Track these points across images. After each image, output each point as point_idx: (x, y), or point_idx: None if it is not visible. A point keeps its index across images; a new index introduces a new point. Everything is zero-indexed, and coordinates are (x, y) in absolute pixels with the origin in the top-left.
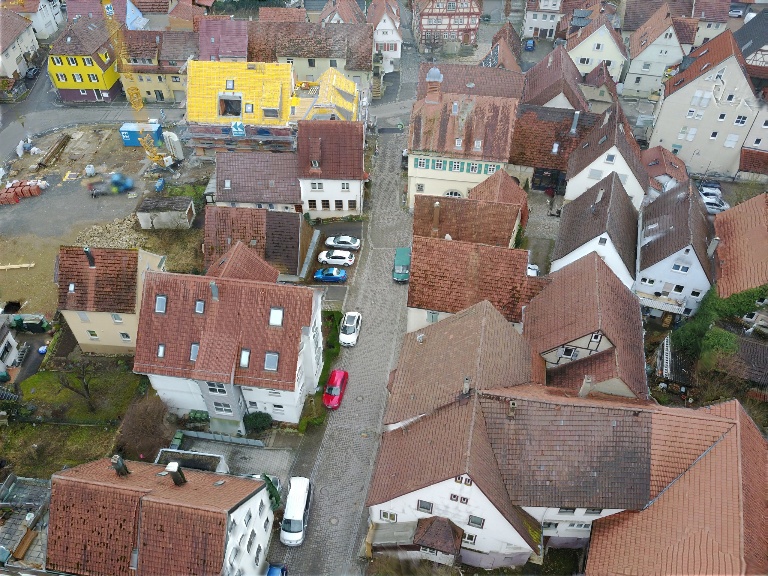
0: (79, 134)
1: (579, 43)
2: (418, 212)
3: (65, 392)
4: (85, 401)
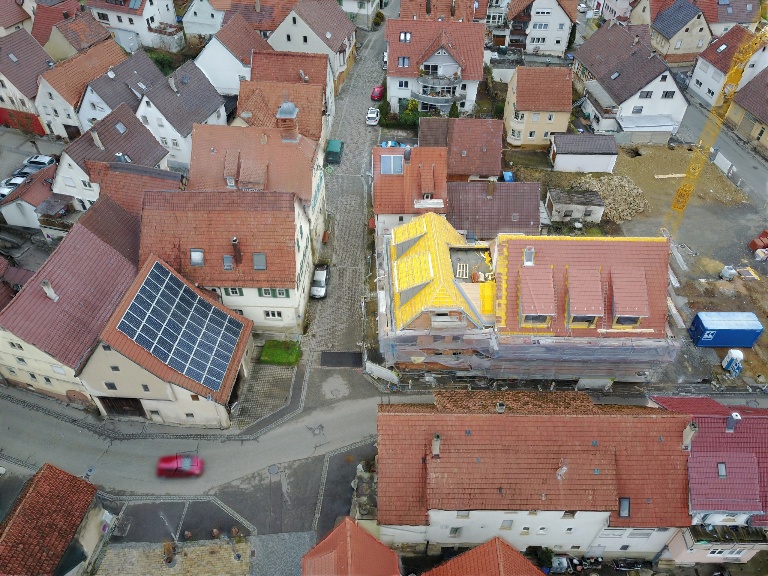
0: None
1: None
2: None
3: None
4: None
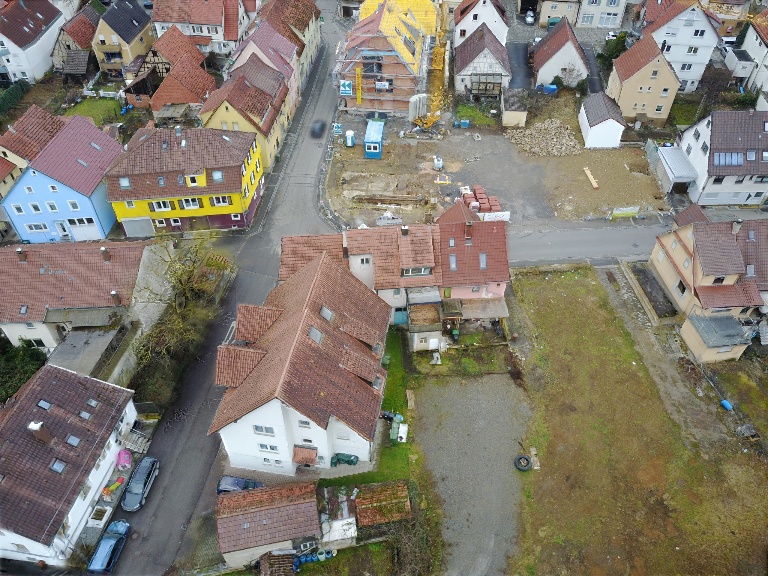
0: (350, 193)
1: None
2: None
3: None
4: None
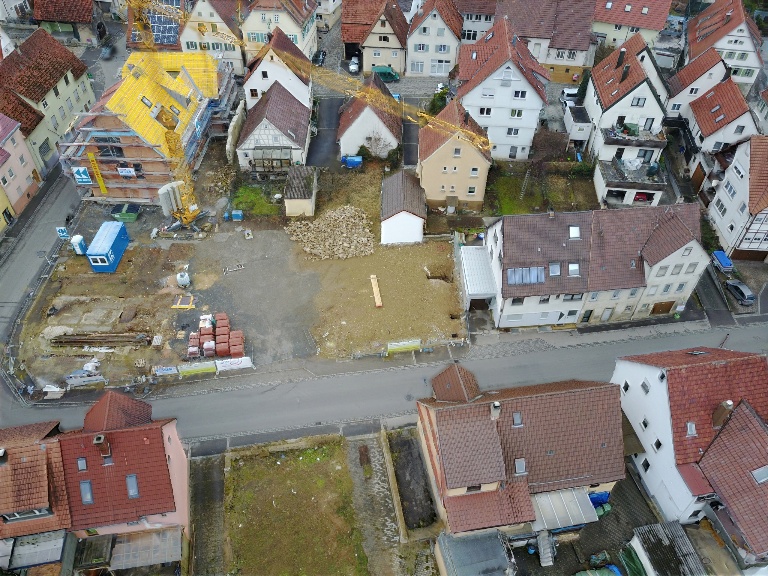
0: (53, 330)
1: None
2: None
3: (521, 211)
4: (525, 200)
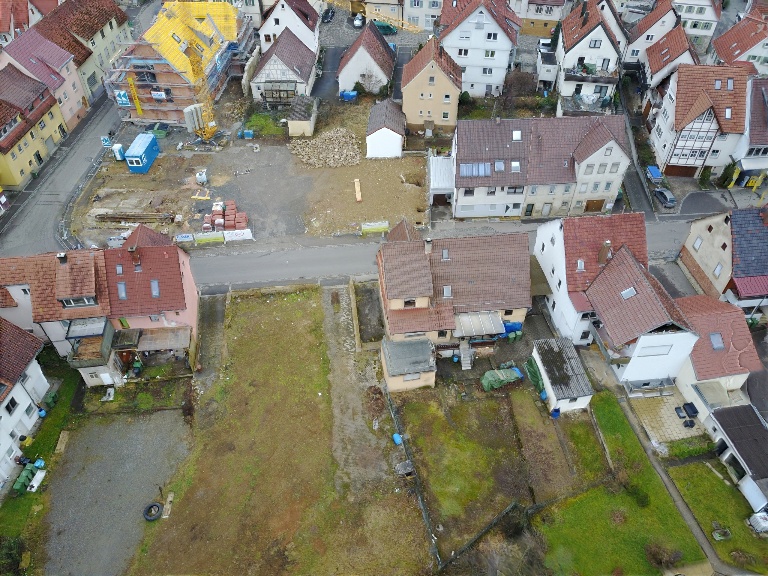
0: (97, 211)
1: None
2: None
3: None
4: None
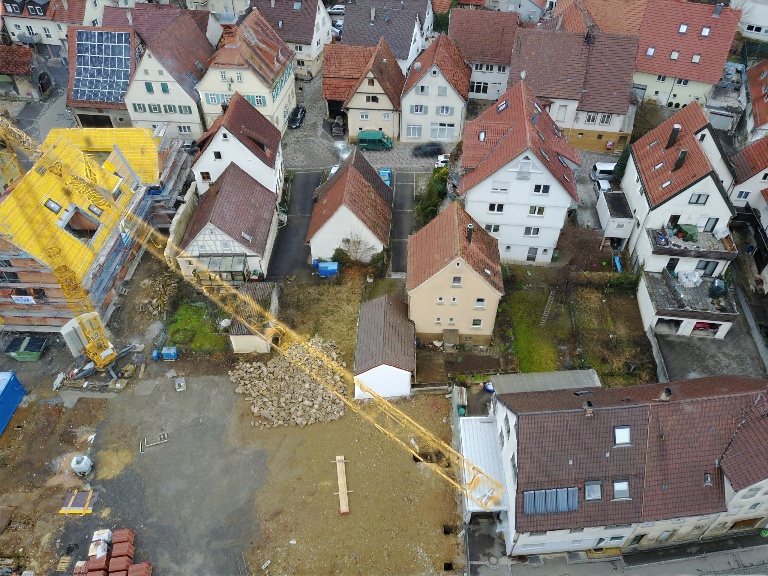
0: None
1: (85, 8)
2: (379, 79)
3: (542, 346)
4: (548, 326)
